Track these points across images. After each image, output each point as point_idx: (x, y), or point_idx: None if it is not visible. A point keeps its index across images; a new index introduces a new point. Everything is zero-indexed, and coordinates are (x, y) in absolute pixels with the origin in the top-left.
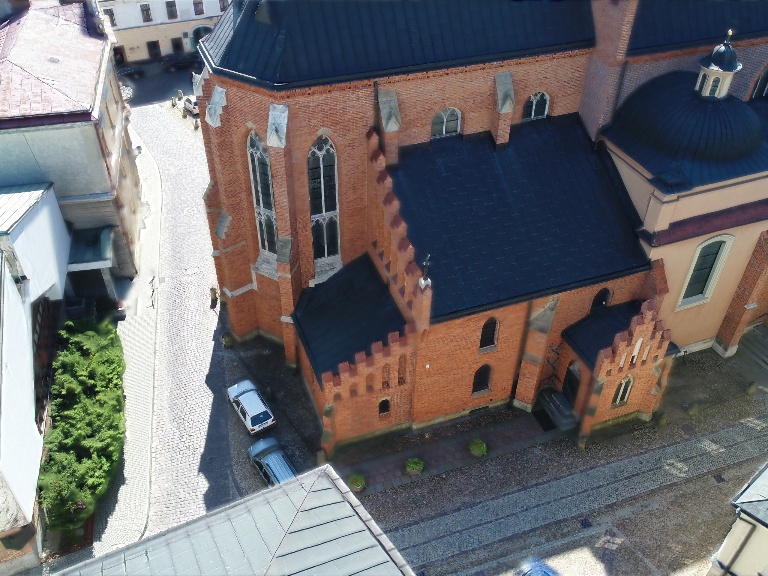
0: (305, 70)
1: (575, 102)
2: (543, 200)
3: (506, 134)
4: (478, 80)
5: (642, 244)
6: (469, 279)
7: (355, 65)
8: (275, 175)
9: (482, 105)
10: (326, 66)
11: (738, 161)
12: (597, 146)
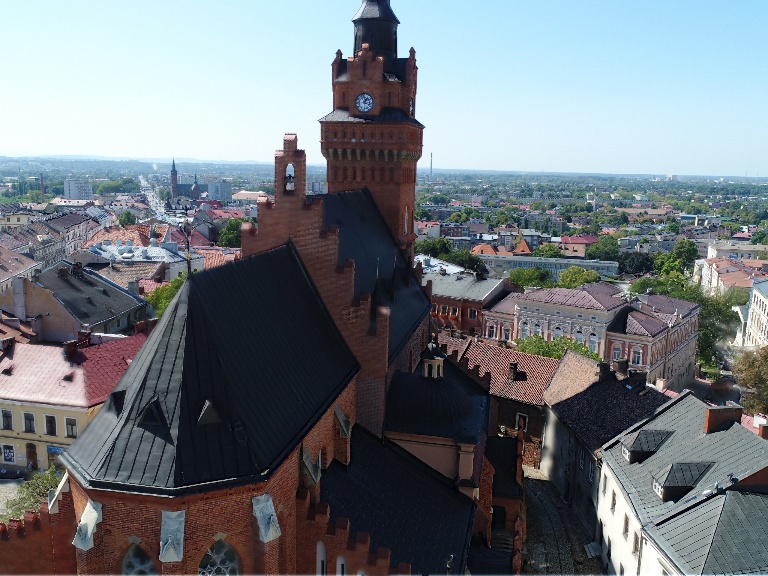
0: (268, 452)
1: (354, 415)
2: (399, 493)
3: (349, 455)
4: (329, 417)
5: (463, 492)
6: (432, 575)
7: (287, 434)
8: (268, 575)
9: (331, 438)
10: (275, 442)
11: (472, 411)
12: (384, 441)
